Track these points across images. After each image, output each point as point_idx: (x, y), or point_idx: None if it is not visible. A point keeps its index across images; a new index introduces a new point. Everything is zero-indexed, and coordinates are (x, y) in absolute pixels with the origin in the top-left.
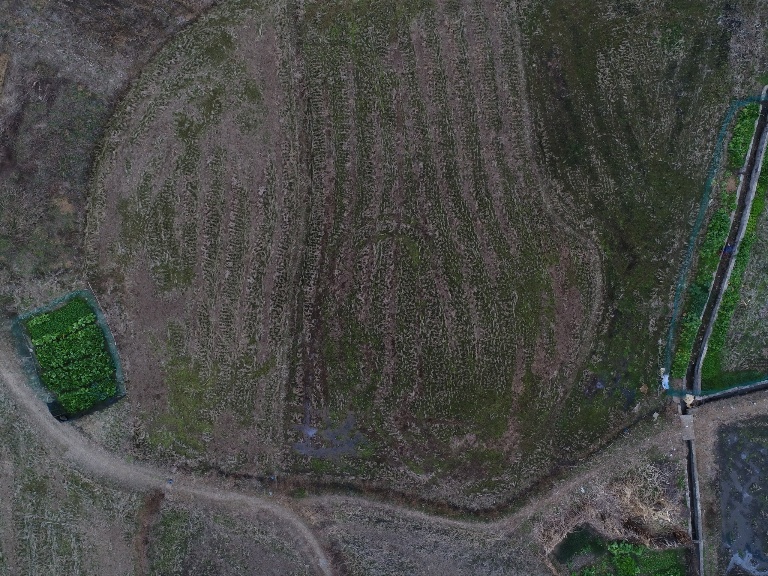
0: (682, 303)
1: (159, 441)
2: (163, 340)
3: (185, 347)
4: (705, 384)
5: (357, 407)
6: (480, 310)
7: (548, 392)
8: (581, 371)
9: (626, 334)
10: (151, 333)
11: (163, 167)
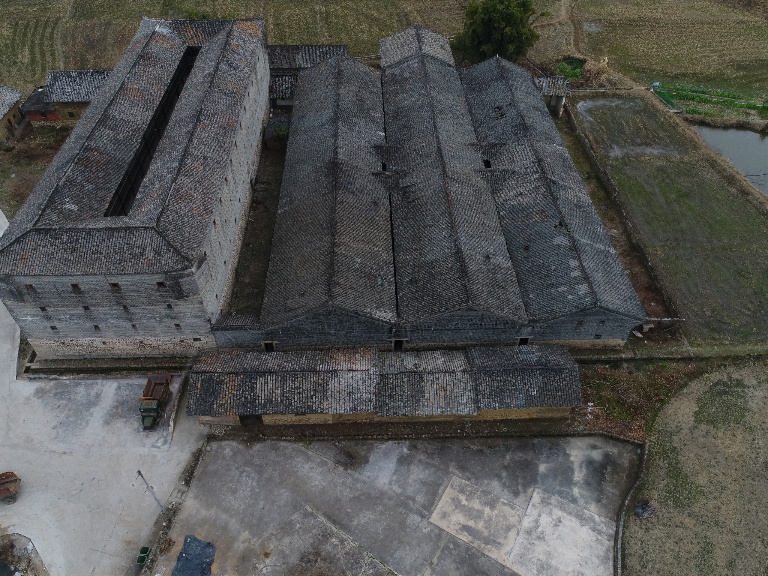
0: None
1: None
2: (613, 3)
3: (613, 6)
4: None
5: None
6: None
7: None
8: None
9: None
10: None
11: (675, 3)
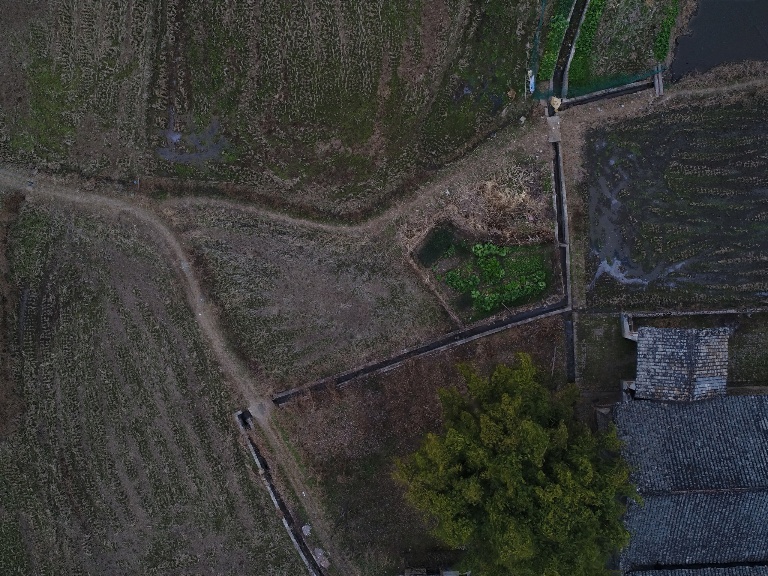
0: (550, 7)
1: (21, 145)
2: (25, 42)
3: (47, 48)
4: (572, 85)
5: (221, 111)
6: (345, 12)
7: (414, 95)
8: (448, 76)
9: (494, 38)
10: (13, 35)
11: None
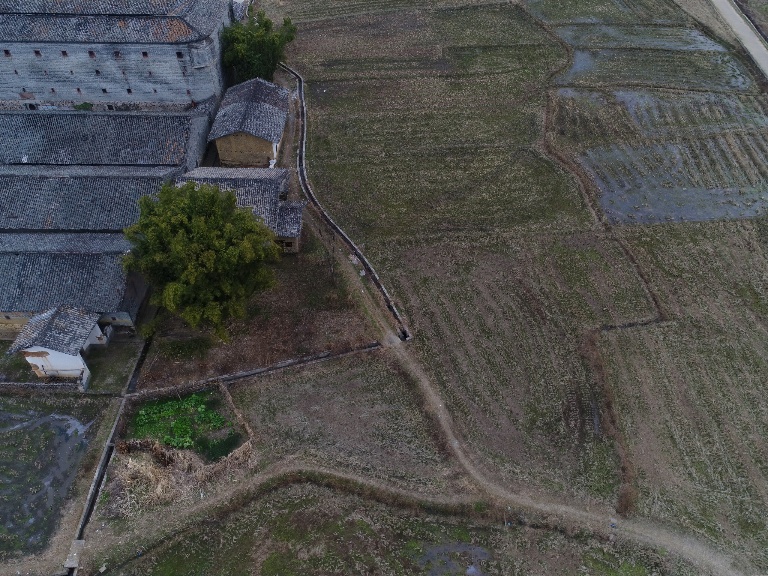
0: None
1: (635, 570)
2: None
3: None
4: None
5: None
6: None
7: None
8: None
9: None
10: None
11: None
